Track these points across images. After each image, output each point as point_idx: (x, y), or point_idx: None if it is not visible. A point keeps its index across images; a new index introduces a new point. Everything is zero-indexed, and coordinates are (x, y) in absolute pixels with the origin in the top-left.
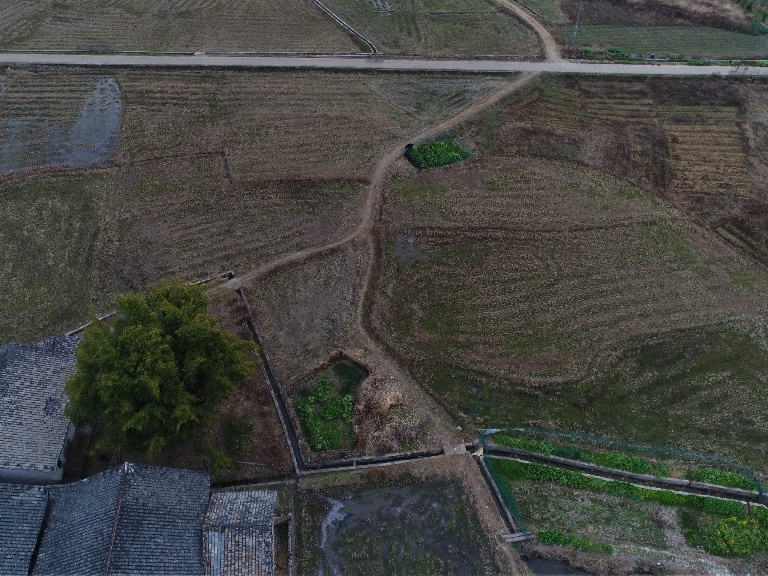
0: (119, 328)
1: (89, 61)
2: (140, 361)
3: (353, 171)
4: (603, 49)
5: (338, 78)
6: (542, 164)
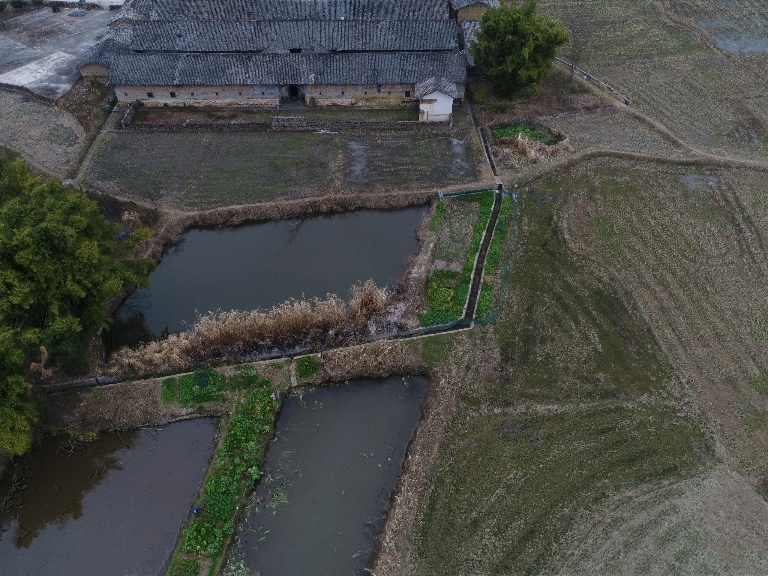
0: None
1: None
2: None
3: None
4: None
5: None
6: None
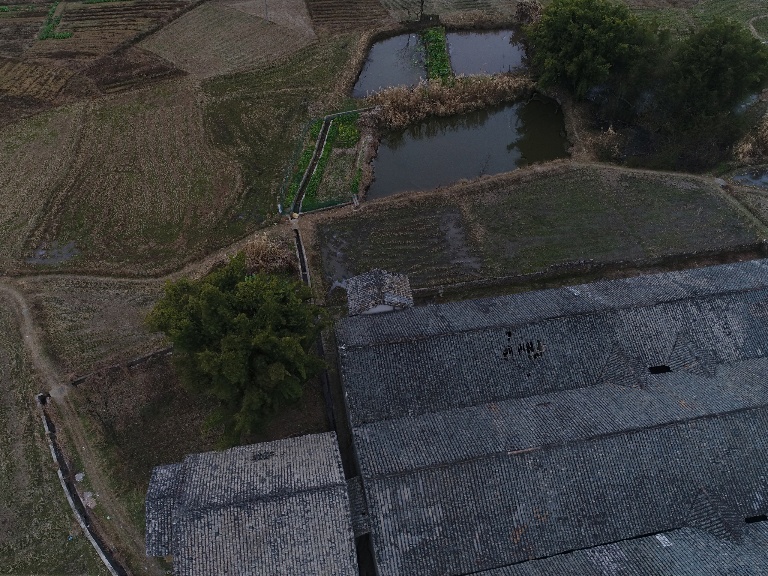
0: (231, 313)
1: None
2: None
3: None
4: None
5: None
6: None
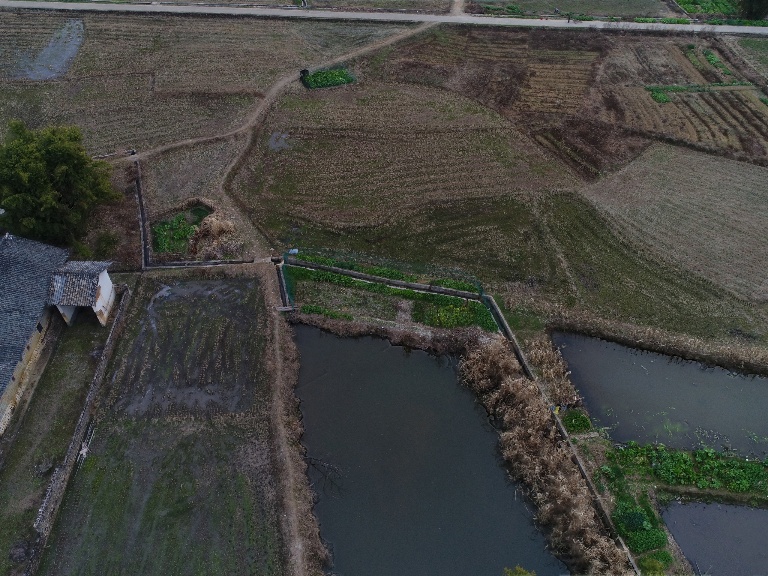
0: (9, 143)
1: (63, 7)
2: (18, 162)
3: (254, 89)
4: (504, 7)
5: (266, 24)
6: (412, 88)
